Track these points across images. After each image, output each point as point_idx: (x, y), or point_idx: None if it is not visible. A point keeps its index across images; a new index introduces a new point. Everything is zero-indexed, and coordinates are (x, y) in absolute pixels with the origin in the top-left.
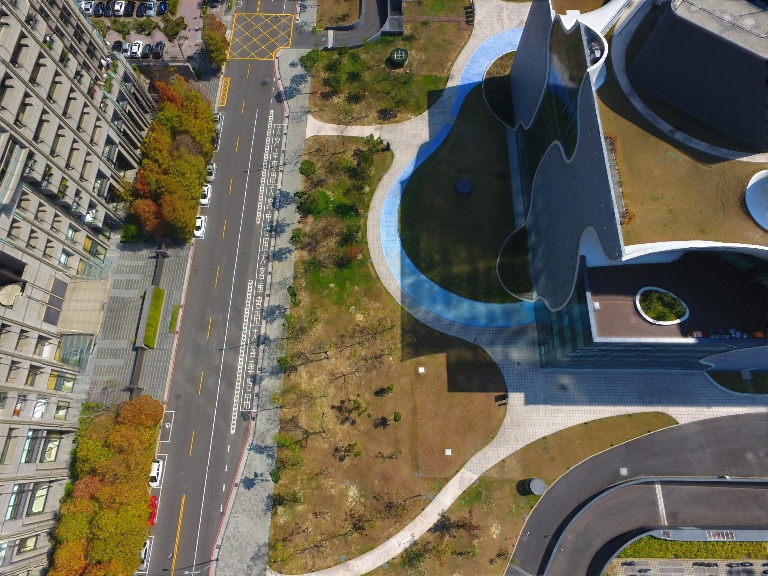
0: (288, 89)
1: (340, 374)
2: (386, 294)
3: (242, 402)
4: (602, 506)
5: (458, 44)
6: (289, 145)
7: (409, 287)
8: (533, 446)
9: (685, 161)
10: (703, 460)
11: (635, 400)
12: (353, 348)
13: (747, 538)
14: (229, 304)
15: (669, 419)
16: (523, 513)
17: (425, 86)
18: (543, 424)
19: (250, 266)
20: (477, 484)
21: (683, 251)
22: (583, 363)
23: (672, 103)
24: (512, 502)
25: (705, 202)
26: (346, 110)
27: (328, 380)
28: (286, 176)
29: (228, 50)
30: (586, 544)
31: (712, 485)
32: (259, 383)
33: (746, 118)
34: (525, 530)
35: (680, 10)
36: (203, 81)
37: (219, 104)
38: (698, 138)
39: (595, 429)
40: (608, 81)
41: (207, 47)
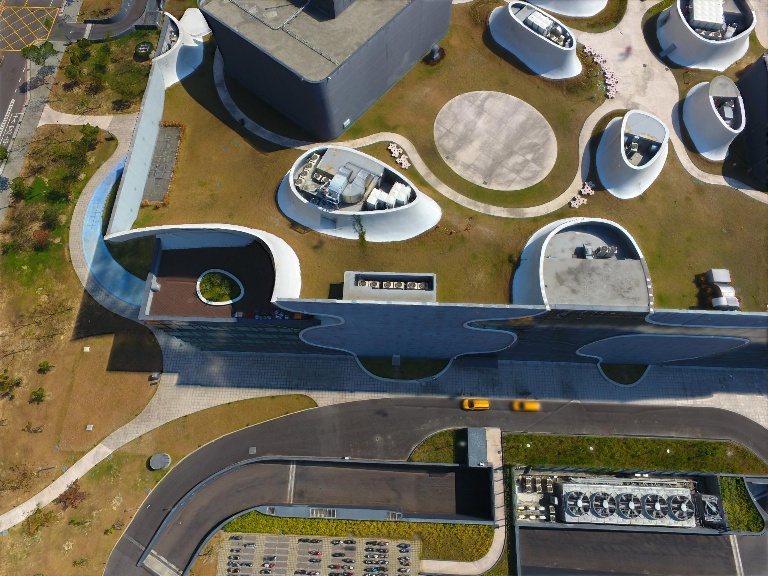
0: (34, 79)
1: (10, 351)
2: (74, 277)
3: None
4: (231, 483)
5: None
6: (20, 133)
7: (97, 270)
8: (172, 424)
9: (245, 149)
10: (332, 441)
11: (282, 383)
12: (29, 327)
13: (348, 516)
14: None
15: (310, 402)
16: (147, 487)
17: None
18: (188, 403)
19: None
20: (110, 458)
21: (223, 234)
22: (221, 345)
23: (256, 94)
24: (139, 476)
25: (249, 188)
26: (83, 100)
27: None
28: (9, 163)
29: None
30: (205, 518)
31: (348, 467)
32: None
33: (295, 108)
34: (146, 503)
35: (211, 3)
36: None
37: None
38: (266, 127)
39: (236, 409)
40: (198, 72)
41: None
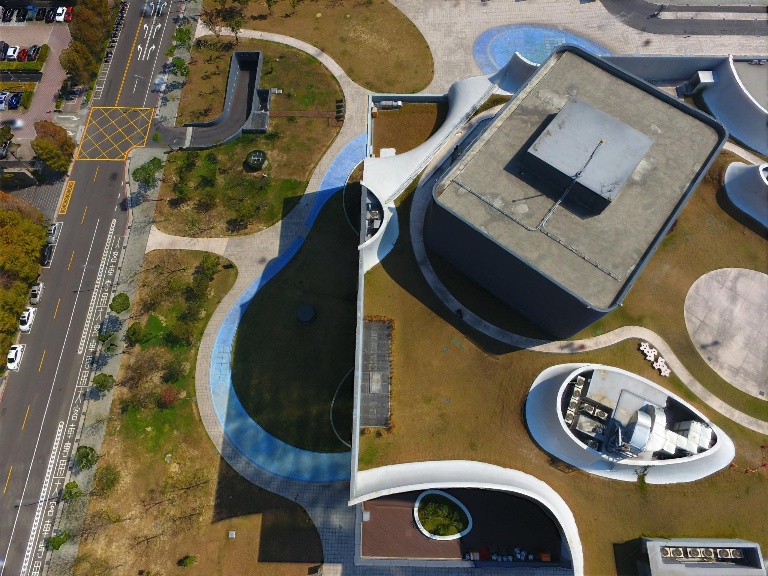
0: (135, 195)
1: (143, 538)
2: (206, 440)
3: (30, 572)
4: None
5: (324, 143)
6: (126, 261)
7: (233, 432)
8: None
9: (470, 350)
10: None
11: (463, 574)
12: (162, 506)
13: None
14: (34, 451)
15: None
16: None
17: (282, 192)
18: None
19: (63, 405)
20: None
21: None
22: None
23: (468, 274)
24: None
25: (484, 404)
26: (193, 220)
27: (129, 545)
28: None
29: (78, 149)
30: None
31: None
32: (52, 548)
33: (534, 306)
34: None
35: (446, 193)
36: (46, 185)
37: (59, 212)
38: (489, 320)
39: None
40: (397, 248)
41: (38, 156)
